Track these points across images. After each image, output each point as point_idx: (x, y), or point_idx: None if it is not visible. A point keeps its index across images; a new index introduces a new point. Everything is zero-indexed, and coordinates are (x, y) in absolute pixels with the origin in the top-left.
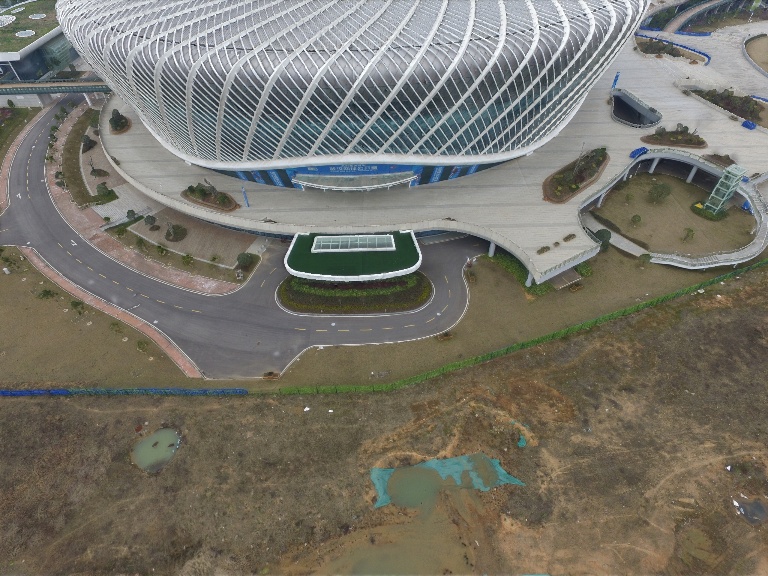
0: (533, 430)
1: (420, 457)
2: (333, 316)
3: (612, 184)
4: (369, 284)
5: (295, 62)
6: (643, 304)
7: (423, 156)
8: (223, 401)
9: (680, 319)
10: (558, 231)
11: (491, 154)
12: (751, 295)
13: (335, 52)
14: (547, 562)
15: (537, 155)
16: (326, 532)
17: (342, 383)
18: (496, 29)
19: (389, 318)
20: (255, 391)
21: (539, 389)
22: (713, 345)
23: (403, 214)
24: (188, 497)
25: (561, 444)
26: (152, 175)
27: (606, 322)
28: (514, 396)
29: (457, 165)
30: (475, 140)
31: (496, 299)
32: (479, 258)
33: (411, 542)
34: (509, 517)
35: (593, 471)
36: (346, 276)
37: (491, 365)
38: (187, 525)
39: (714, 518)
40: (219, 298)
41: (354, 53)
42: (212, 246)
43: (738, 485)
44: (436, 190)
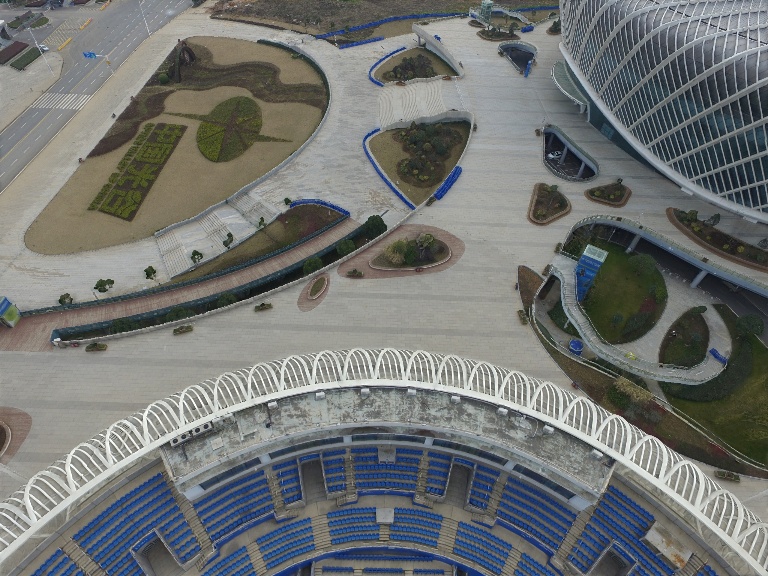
0: None
1: None
2: None
3: None
4: None
5: None
6: (538, 7)
7: None
8: None
9: (523, 6)
10: None
11: None
12: None
13: None
14: None
15: None
16: None
17: None
18: None
19: None
20: None
21: None
22: None
23: None
24: None
25: None
26: None
27: None
28: None
29: None
30: None
31: None
32: None
33: None
34: None
35: None
36: None
37: None
38: None
39: None
40: None
41: None
42: None
43: None
44: None
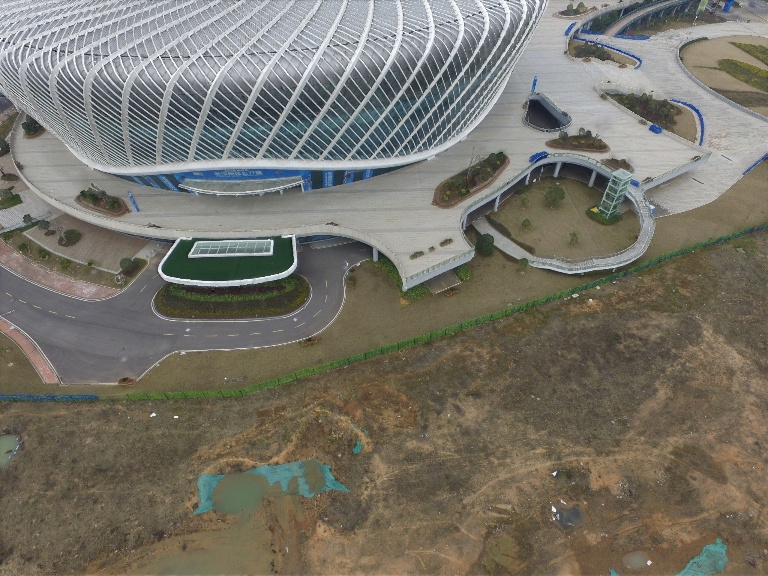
0: (371, 436)
1: (251, 463)
2: (204, 321)
3: (505, 188)
4: (247, 289)
5: (149, 68)
6: (511, 309)
7: (305, 161)
8: (71, 407)
9: (546, 324)
10: (437, 236)
11: (383, 159)
12: (622, 300)
13: (189, 58)
14: (349, 569)
15: (439, 159)
16: (139, 539)
17: (195, 389)
18: (357, 35)
19: (259, 323)
20: (106, 397)
21: (388, 394)
22: (570, 350)
23: (289, 219)
24: (11, 504)
25: (395, 450)
26: (52, 180)
27: (473, 327)
28: (361, 402)
29: (347, 170)
30: (358, 145)
31: (370, 304)
32: (364, 263)
33: (222, 549)
34: (324, 523)
35: (419, 477)
36: (216, 281)
37: (348, 370)
38: (2, 532)
39: (527, 524)
40: (96, 303)
41: (208, 59)
42: (102, 251)
43: (560, 491)
44: (329, 195)
